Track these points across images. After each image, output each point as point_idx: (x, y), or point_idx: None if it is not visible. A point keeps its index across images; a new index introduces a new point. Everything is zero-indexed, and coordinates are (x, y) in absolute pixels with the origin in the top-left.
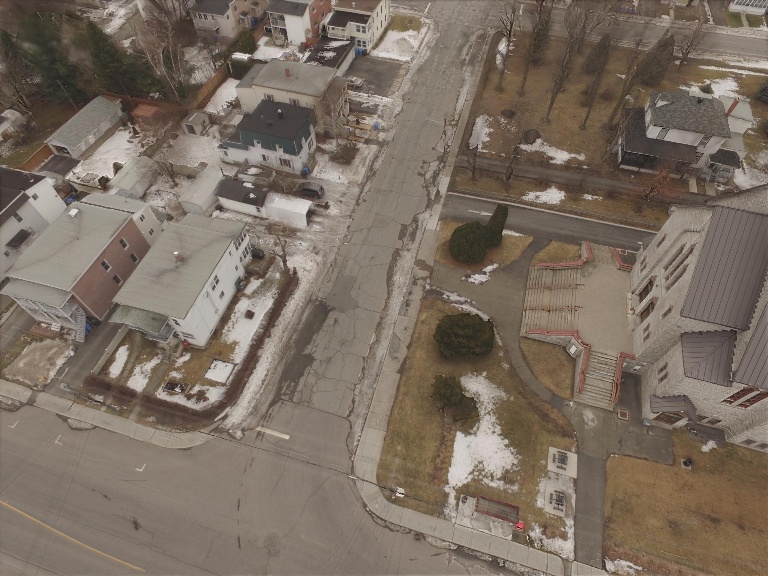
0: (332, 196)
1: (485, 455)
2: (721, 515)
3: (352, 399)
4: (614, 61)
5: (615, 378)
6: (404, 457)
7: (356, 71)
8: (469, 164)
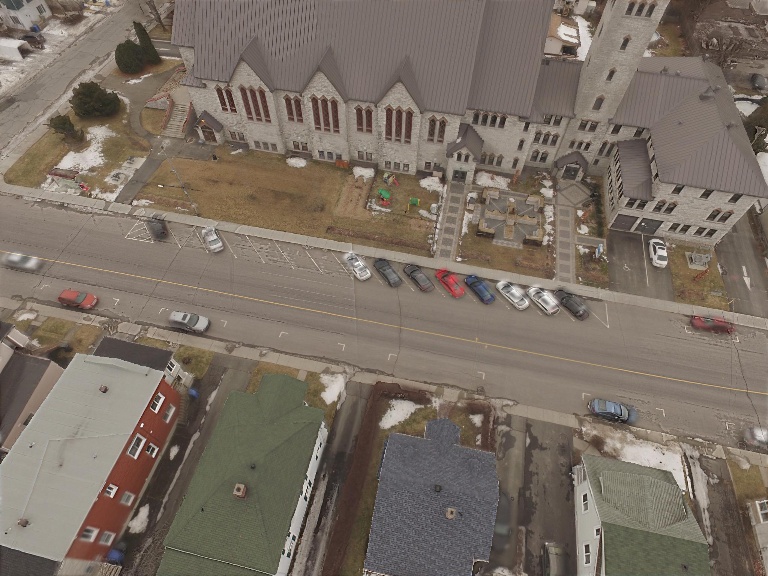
0: (51, 43)
1: (83, 161)
2: (221, 179)
3: (8, 141)
4: None
5: (186, 118)
6: (27, 164)
7: None
8: (154, 16)
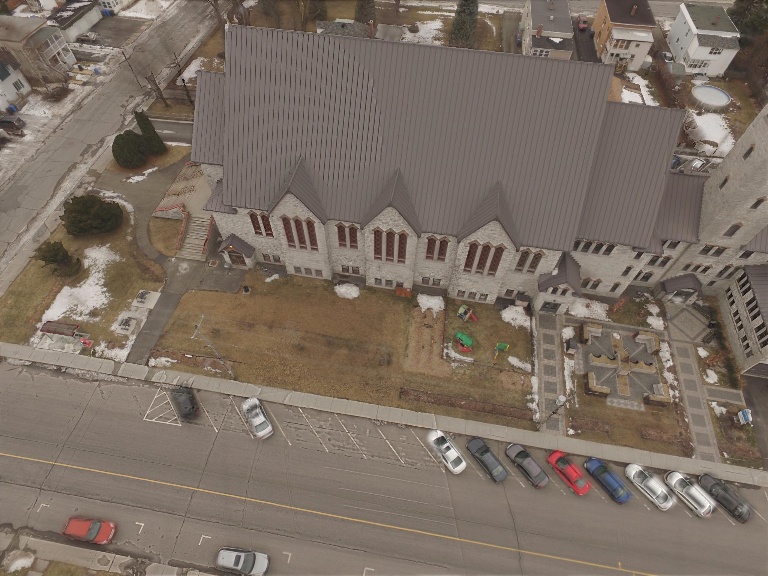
0: (32, 127)
1: (82, 300)
2: (258, 321)
3: None
4: (343, 11)
5: (207, 235)
6: (11, 307)
7: (99, 29)
8: (154, 91)
